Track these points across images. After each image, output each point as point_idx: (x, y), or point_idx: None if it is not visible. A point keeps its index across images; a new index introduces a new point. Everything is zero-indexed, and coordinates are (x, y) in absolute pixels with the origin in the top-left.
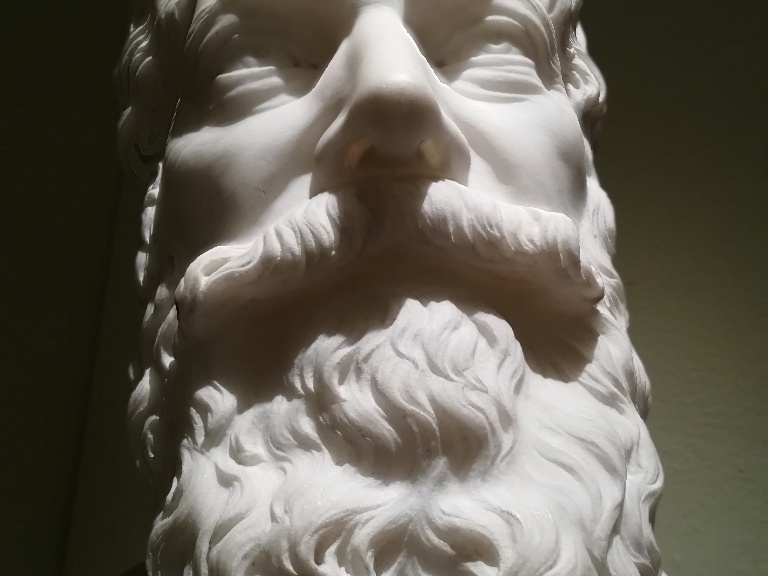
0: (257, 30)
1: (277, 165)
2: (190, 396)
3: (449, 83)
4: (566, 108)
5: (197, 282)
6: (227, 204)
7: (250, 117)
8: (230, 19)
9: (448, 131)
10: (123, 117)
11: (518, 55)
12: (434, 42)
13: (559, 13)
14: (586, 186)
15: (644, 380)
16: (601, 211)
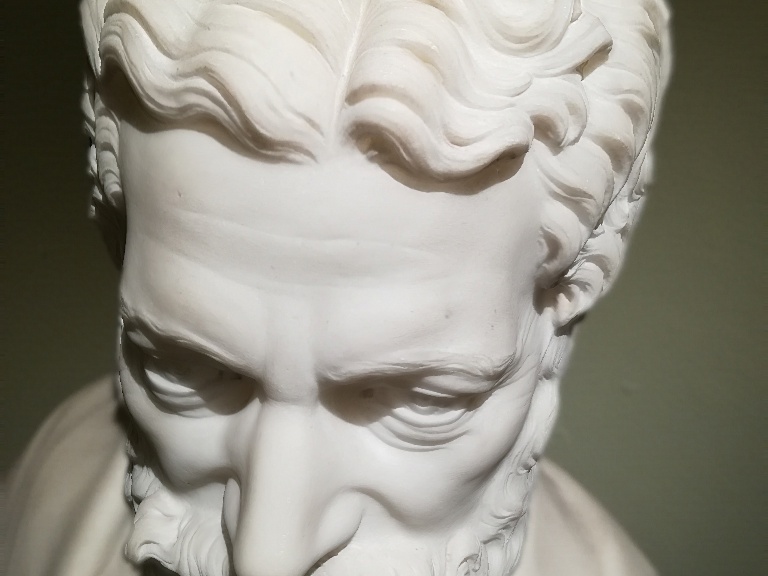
0: (175, 357)
1: (197, 477)
2: (146, 575)
3: (368, 423)
4: (500, 421)
5: (135, 558)
6: (163, 470)
7: (177, 416)
8: (148, 344)
9: None
10: (90, 211)
11: (445, 413)
12: (360, 383)
13: (554, 271)
14: None
15: (507, 575)
16: (531, 444)
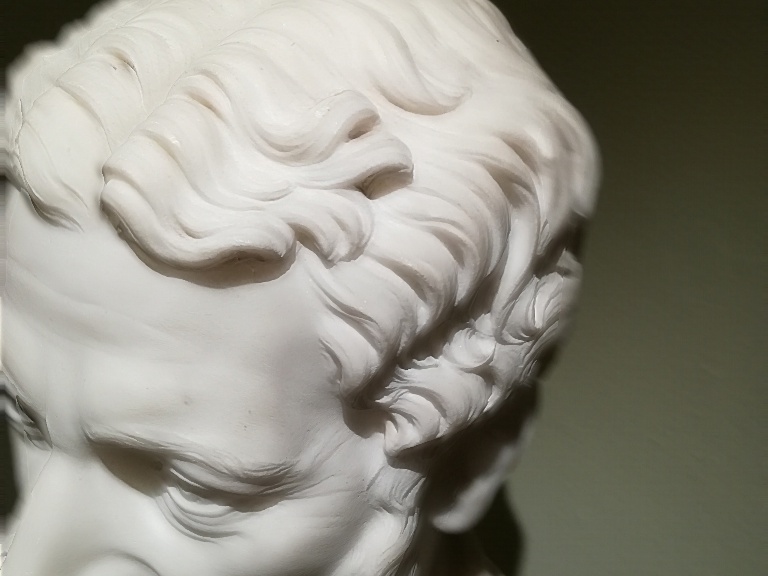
0: None
1: None
2: None
3: (154, 495)
4: (282, 533)
5: None
6: None
7: (32, 443)
8: None
9: None
10: None
11: (206, 505)
12: (145, 452)
13: (343, 390)
14: (333, 563)
15: None
16: None
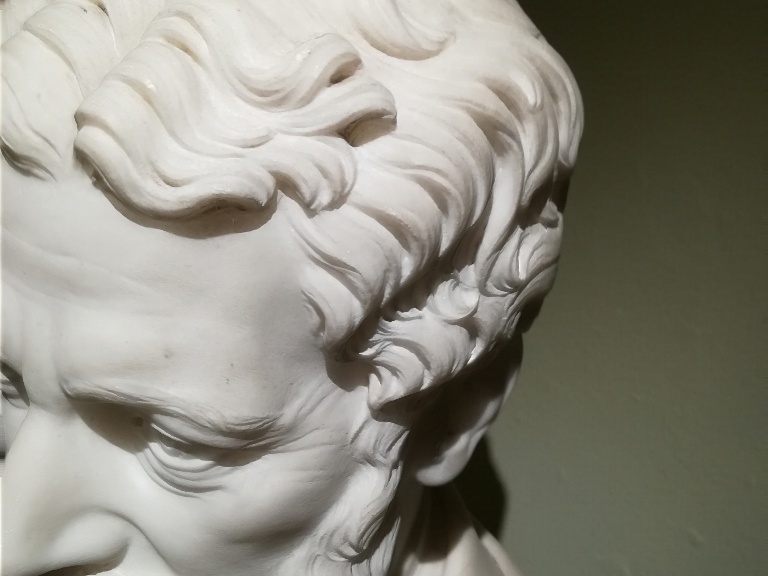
0: None
1: None
2: None
3: (135, 451)
4: (266, 487)
5: None
6: None
7: (8, 402)
8: None
9: (61, 566)
10: None
11: (189, 460)
12: (125, 408)
13: (326, 343)
14: (318, 517)
15: None
16: (341, 530)
